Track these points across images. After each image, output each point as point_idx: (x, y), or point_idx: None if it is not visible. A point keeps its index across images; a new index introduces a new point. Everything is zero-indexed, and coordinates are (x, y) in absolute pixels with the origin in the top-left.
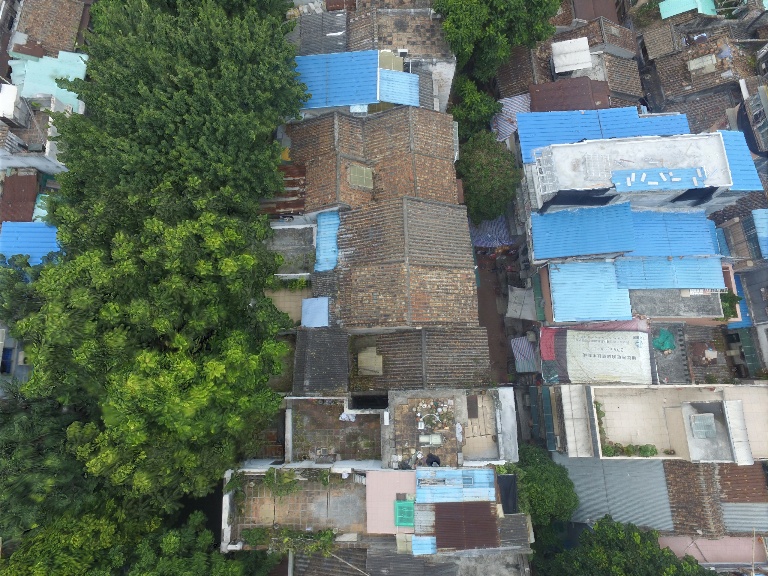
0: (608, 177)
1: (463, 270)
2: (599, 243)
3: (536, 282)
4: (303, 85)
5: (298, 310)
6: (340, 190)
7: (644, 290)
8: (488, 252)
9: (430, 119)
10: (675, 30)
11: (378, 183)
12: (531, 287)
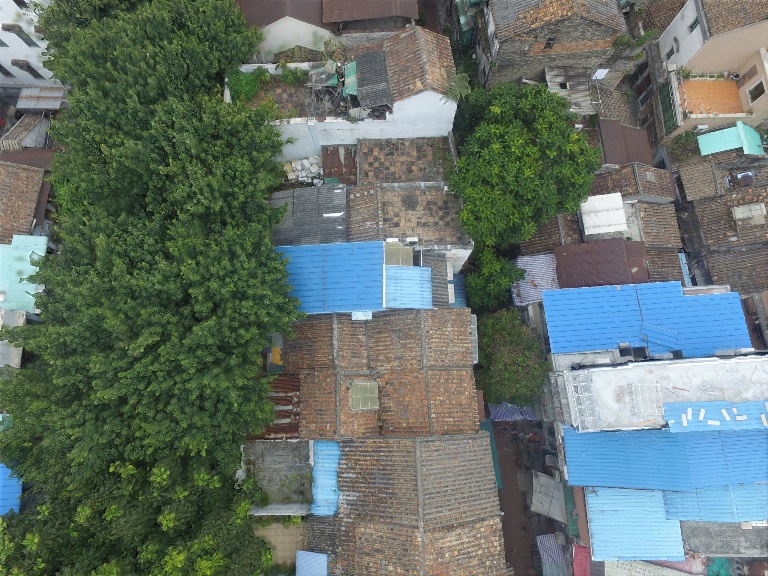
0: (660, 414)
1: (487, 521)
2: (646, 476)
3: (567, 486)
4: (295, 301)
5: (292, 547)
6: (340, 420)
7: None
8: (509, 429)
9: (445, 319)
10: (716, 168)
11: (385, 399)
12: (560, 481)
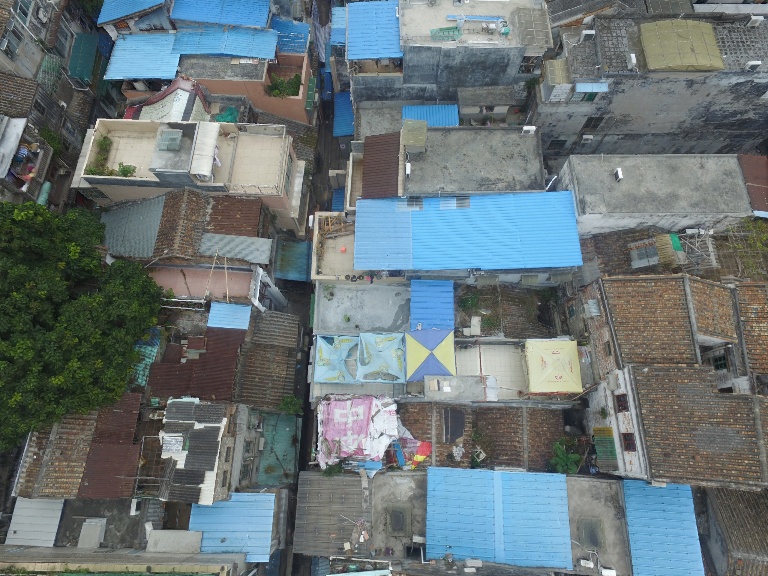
0: None
1: None
2: (143, 2)
3: None
4: None
5: None
6: None
7: (199, 58)
8: None
9: None
10: None
11: None
12: None
